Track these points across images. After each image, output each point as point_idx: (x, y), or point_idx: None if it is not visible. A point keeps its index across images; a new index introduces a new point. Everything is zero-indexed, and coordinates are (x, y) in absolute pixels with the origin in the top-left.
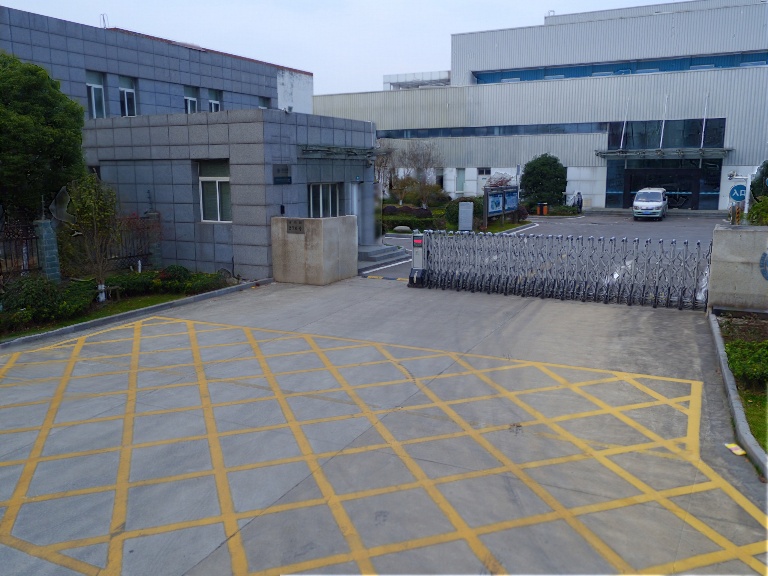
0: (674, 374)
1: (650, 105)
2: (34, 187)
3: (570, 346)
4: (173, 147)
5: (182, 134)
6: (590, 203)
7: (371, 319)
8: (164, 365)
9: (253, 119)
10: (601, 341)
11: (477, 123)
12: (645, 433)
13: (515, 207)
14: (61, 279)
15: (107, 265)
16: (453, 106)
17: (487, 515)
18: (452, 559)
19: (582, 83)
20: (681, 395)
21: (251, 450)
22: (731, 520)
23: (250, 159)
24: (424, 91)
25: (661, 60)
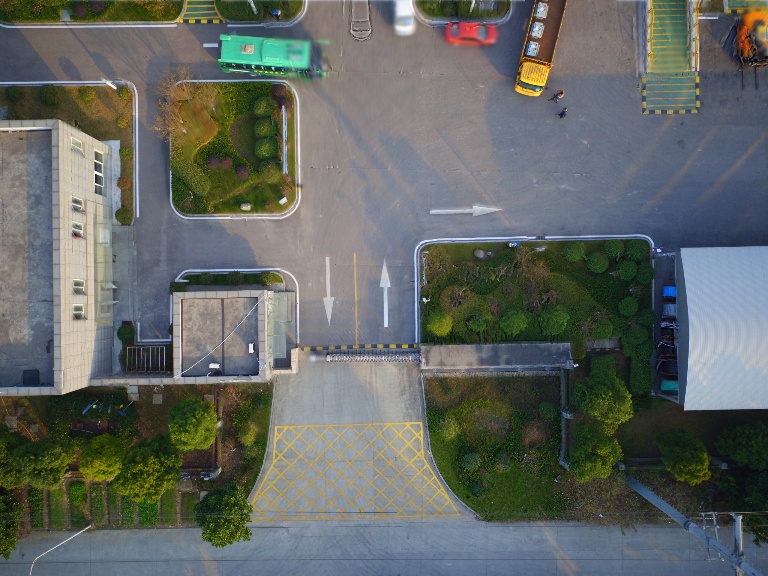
0: (417, 420)
1: None
2: None
3: (393, 409)
4: None
5: None
6: None
7: (337, 405)
8: (314, 459)
9: None
10: (399, 402)
11: None
12: (416, 452)
13: None
14: None
15: None
16: None
17: (401, 487)
18: (401, 498)
19: None
20: (419, 431)
21: (361, 485)
22: (429, 474)
23: None
24: None
25: None
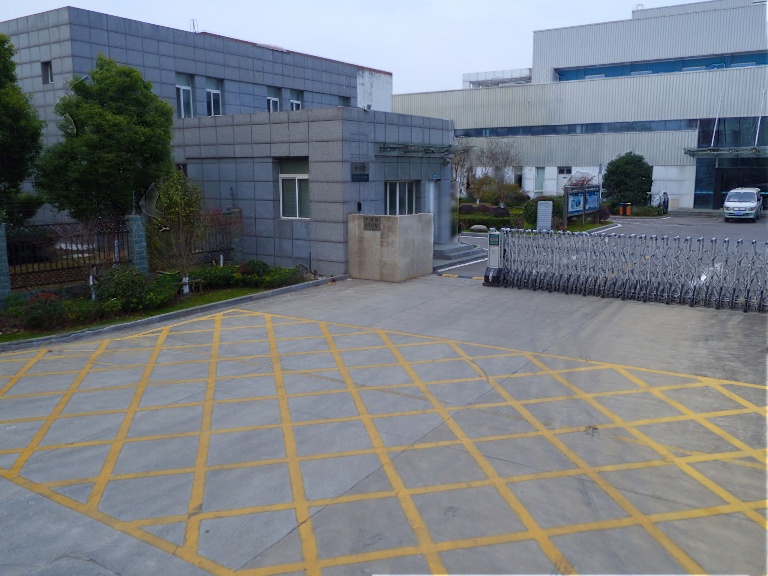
0: (765, 381)
1: (745, 100)
2: (126, 183)
3: (652, 349)
4: (255, 145)
5: (264, 133)
6: (677, 203)
7: (445, 316)
8: (242, 356)
9: (332, 117)
10: (686, 345)
11: (558, 121)
12: (732, 441)
13: (596, 207)
14: (149, 271)
15: (191, 259)
16: (534, 104)
17: (560, 517)
18: (522, 559)
19: (671, 78)
20: None
21: (323, 440)
22: None
23: (329, 157)
24: (504, 89)
25: (758, 53)
